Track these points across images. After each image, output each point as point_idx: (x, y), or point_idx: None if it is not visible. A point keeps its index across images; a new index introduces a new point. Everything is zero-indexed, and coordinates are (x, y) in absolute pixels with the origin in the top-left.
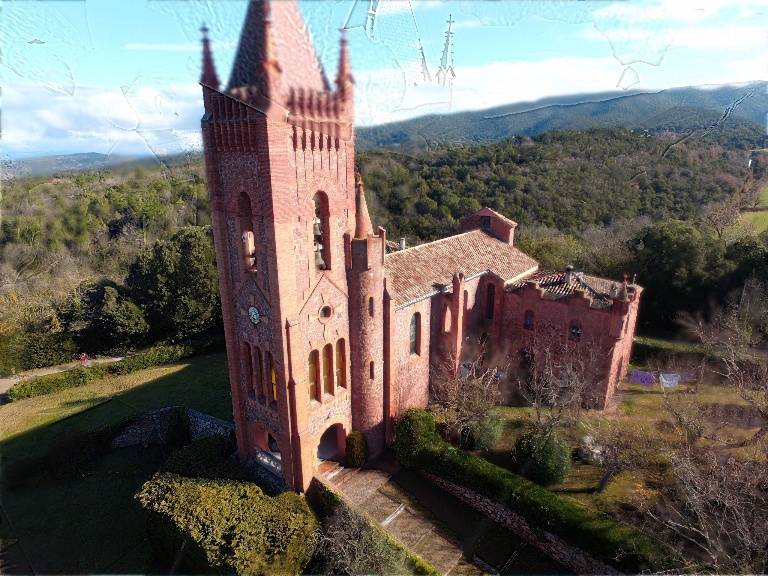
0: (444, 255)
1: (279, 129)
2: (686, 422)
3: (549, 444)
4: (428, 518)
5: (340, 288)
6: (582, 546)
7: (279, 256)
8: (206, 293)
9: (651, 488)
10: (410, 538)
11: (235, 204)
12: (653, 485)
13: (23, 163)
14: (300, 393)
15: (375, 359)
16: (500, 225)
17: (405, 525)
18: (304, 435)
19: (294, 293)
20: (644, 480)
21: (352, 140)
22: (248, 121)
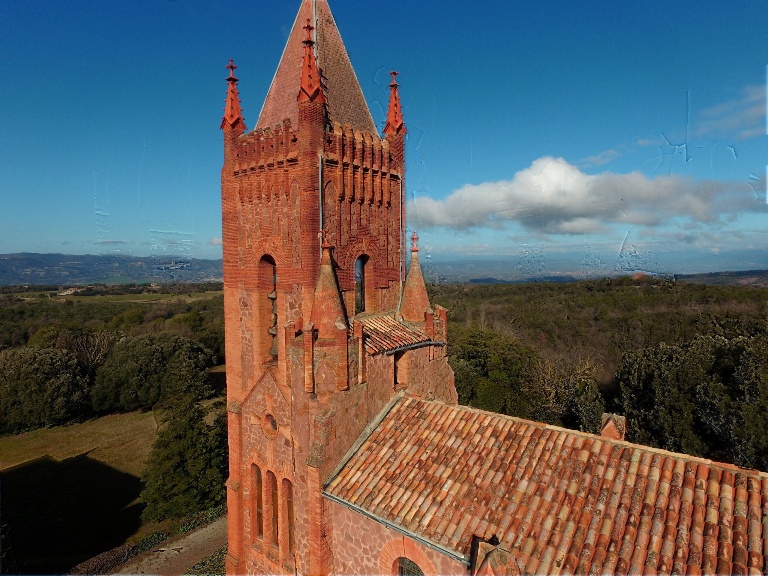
0: (726, 526)
1: (231, 185)
2: None
3: None
4: None
5: (288, 400)
6: None
7: (227, 324)
8: (659, 428)
9: None
10: None
11: None
12: None
13: (650, 253)
14: (232, 502)
15: (297, 556)
16: None
17: None
18: (230, 561)
19: (239, 374)
20: None
21: (309, 180)
22: None
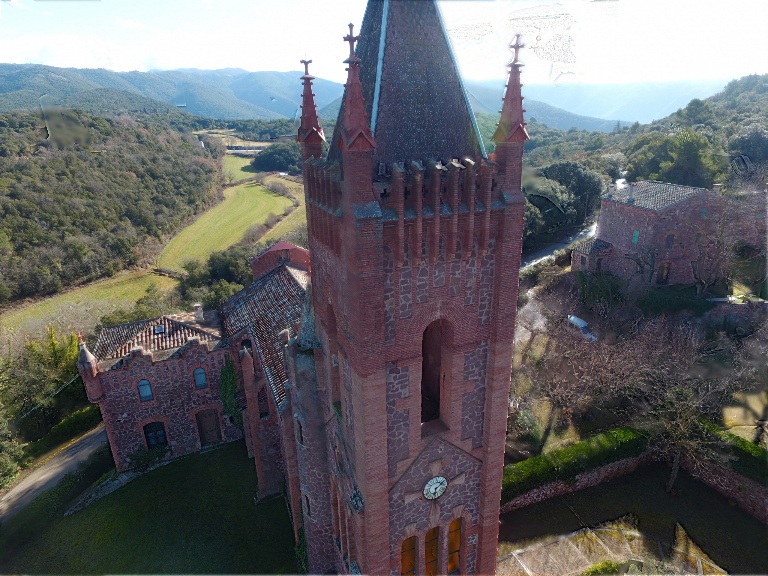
0: None
1: None
2: (532, 356)
3: (531, 419)
4: (530, 543)
5: None
6: (595, 465)
7: None
8: None
9: (551, 407)
10: (552, 567)
11: (415, 344)
12: (549, 405)
13: None
14: None
15: None
16: (302, 256)
17: (537, 564)
18: None
19: None
20: (543, 406)
21: None
22: (489, 212)
